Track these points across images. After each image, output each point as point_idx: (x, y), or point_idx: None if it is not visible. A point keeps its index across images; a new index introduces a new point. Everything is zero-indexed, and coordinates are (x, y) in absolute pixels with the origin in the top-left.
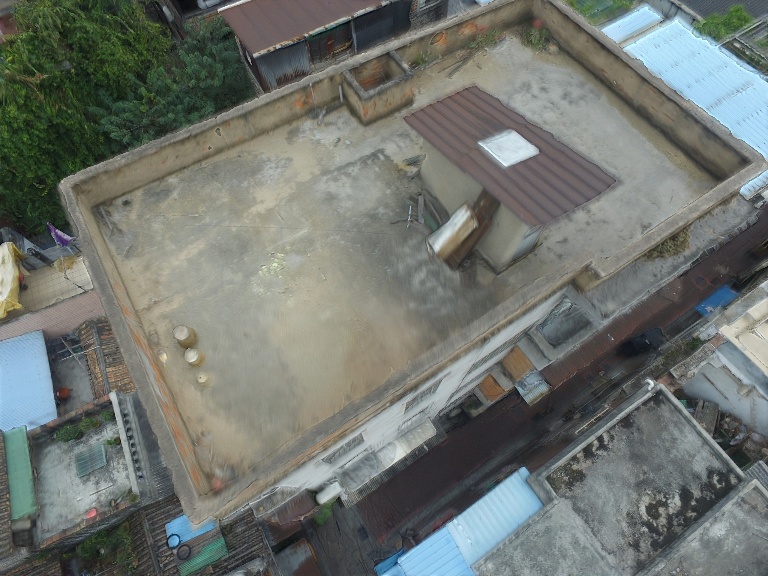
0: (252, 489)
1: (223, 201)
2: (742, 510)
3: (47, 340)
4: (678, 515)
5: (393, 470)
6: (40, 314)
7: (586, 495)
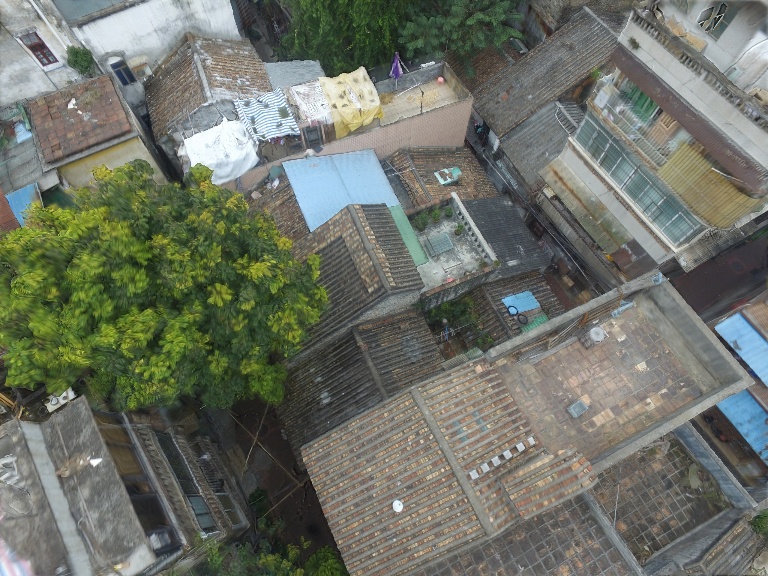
0: None
1: None
2: None
3: None
4: None
5: (719, 247)
6: (385, 129)
7: None
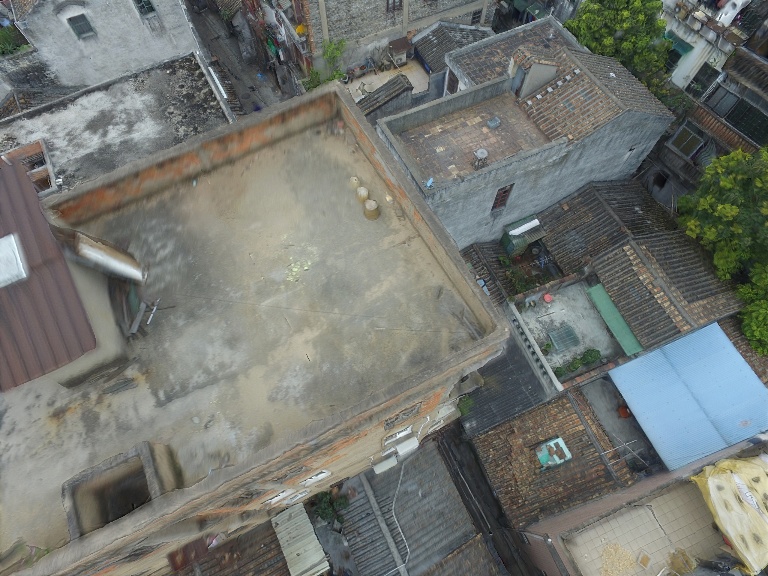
0: None
1: (349, 345)
2: None
3: None
4: None
5: None
6: None
7: None
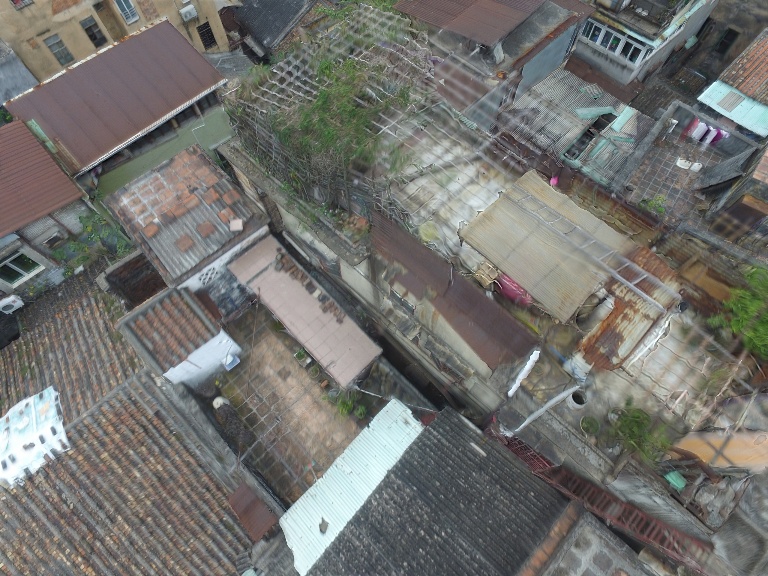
0: None
1: None
2: None
3: None
4: None
5: None
6: None
7: None
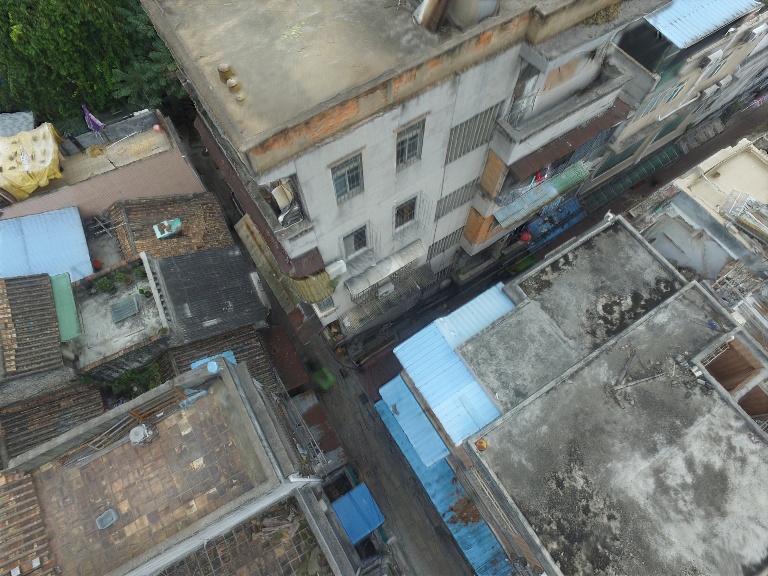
0: (281, 154)
1: None
2: (683, 304)
3: (81, 216)
4: (629, 311)
5: (390, 304)
6: (76, 187)
7: (552, 298)
